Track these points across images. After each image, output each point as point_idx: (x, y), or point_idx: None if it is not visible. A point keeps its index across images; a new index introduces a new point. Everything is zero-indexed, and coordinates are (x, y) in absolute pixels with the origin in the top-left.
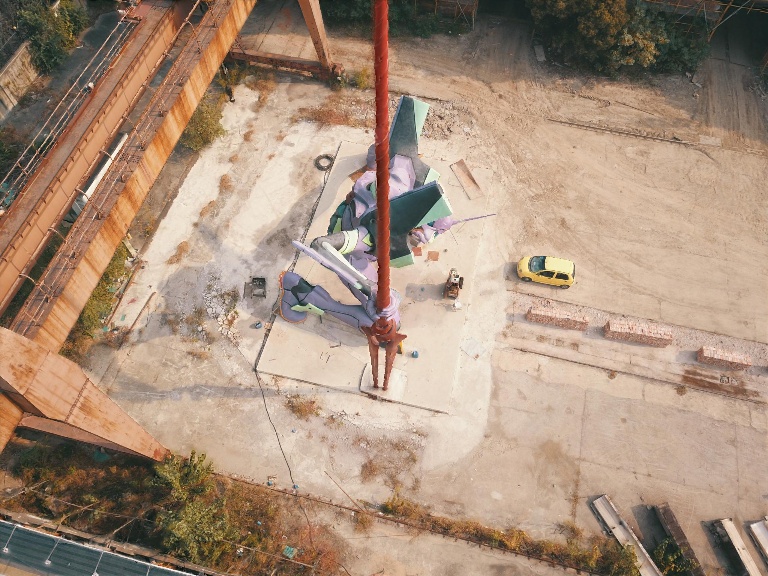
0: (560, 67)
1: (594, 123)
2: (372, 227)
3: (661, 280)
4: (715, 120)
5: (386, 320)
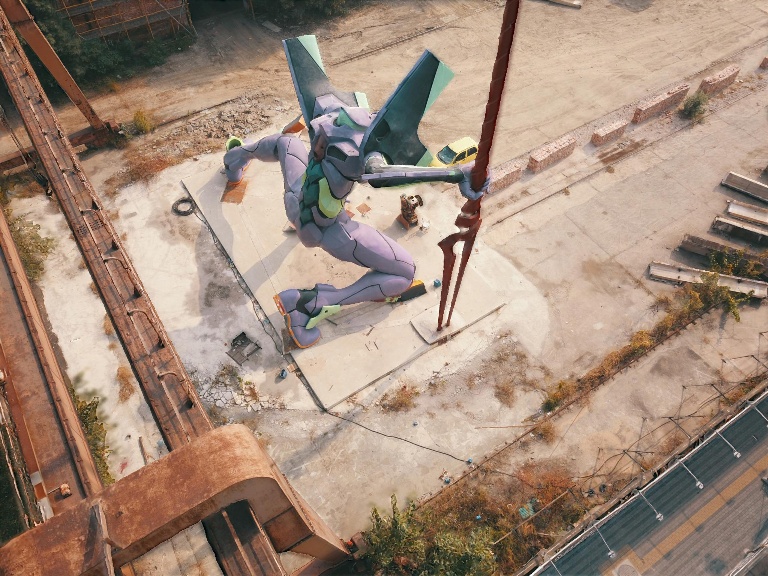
0: (298, 28)
1: (366, 50)
2: (383, 145)
3: (523, 116)
4: (438, 5)
5: (487, 192)
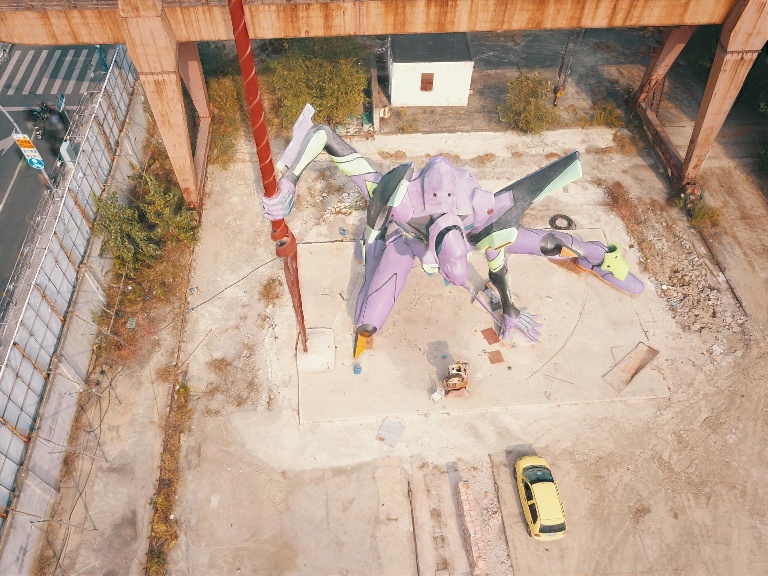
0: None
1: None
2: (381, 179)
3: None
4: None
5: None
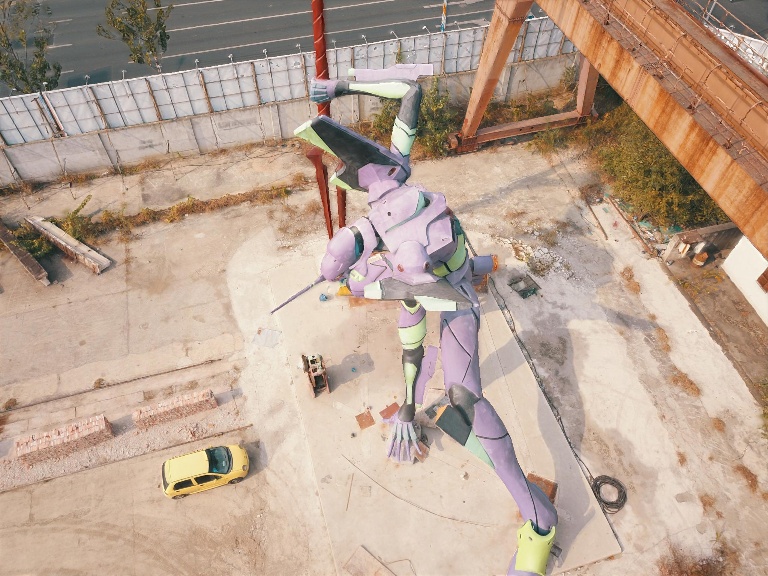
0: None
1: None
2: None
3: (26, 560)
4: None
5: None
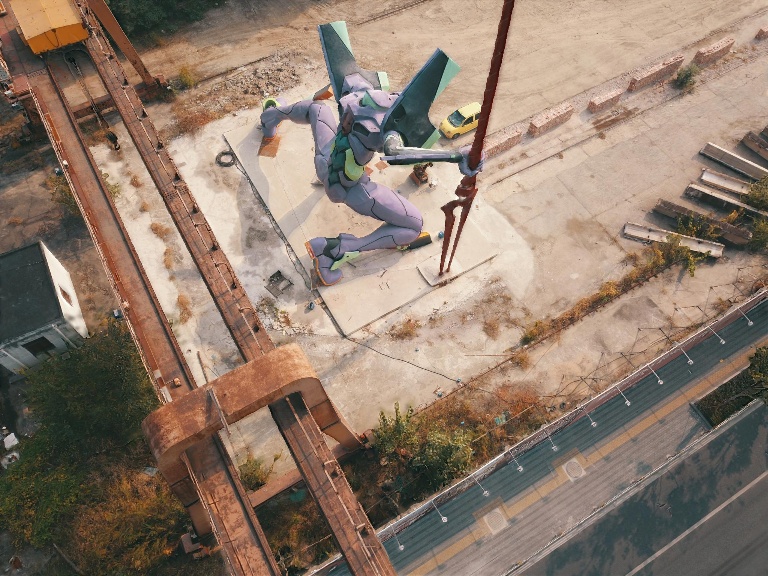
0: None
1: (388, 9)
2: (399, 125)
3: (528, 81)
4: None
5: None
